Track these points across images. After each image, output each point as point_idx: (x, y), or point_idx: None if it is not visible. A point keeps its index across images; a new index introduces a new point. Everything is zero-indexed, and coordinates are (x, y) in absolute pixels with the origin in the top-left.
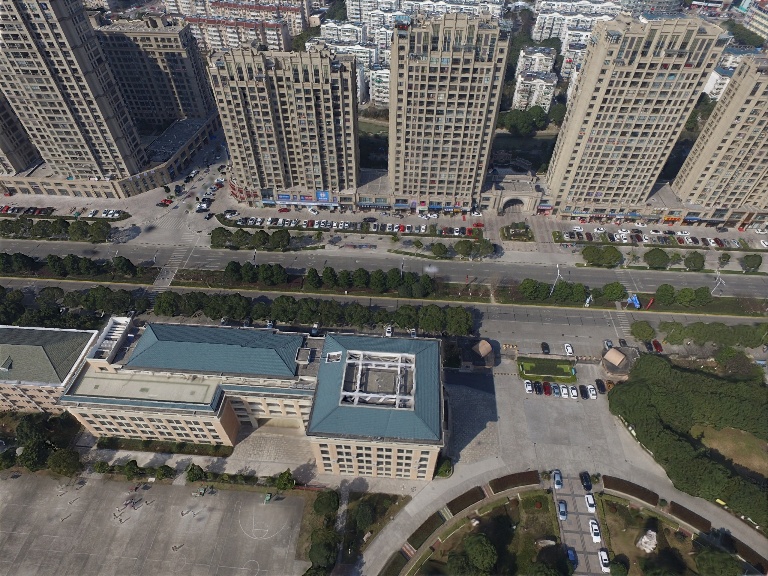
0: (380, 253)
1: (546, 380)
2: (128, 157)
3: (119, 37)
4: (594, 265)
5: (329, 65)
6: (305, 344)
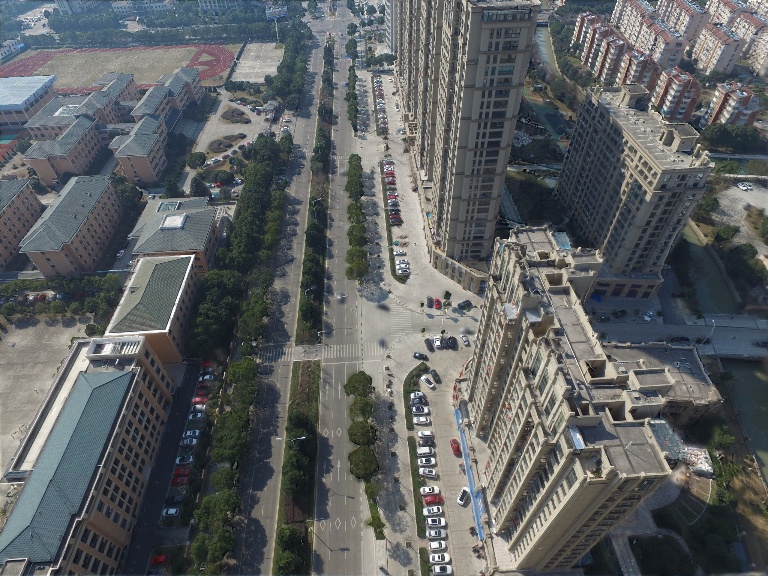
0: None
1: None
2: (456, 240)
3: (618, 130)
4: None
5: (566, 422)
6: (39, 567)
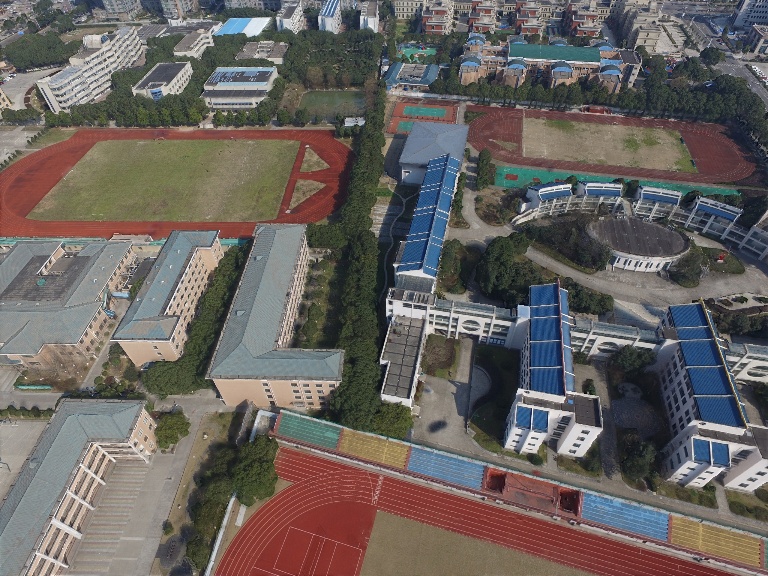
0: None
1: None
2: None
3: None
4: None
5: None
6: None
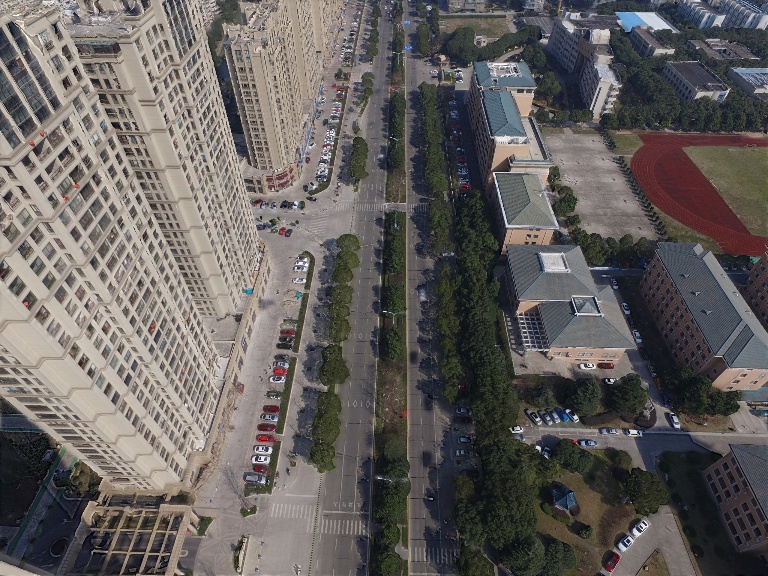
0: (362, 119)
1: (454, 78)
2: None
3: None
4: (371, 61)
5: None
6: None
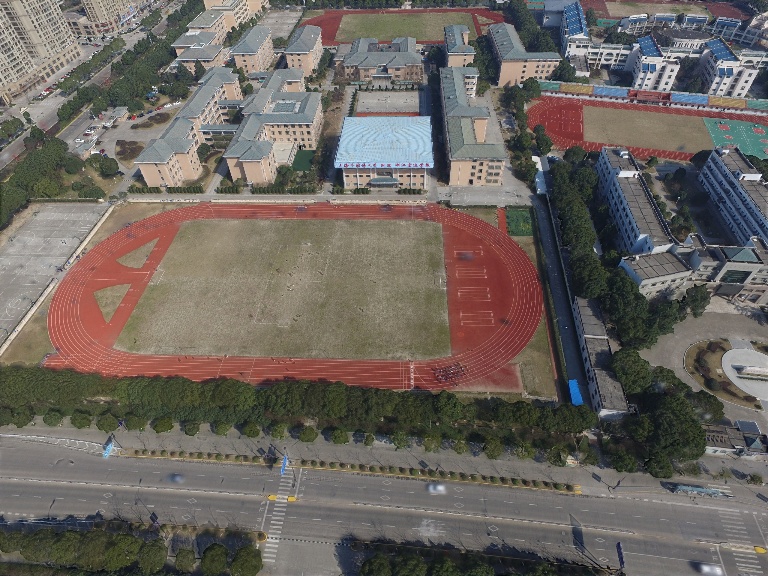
0: (173, 10)
1: None
2: None
3: None
4: None
5: None
6: None
